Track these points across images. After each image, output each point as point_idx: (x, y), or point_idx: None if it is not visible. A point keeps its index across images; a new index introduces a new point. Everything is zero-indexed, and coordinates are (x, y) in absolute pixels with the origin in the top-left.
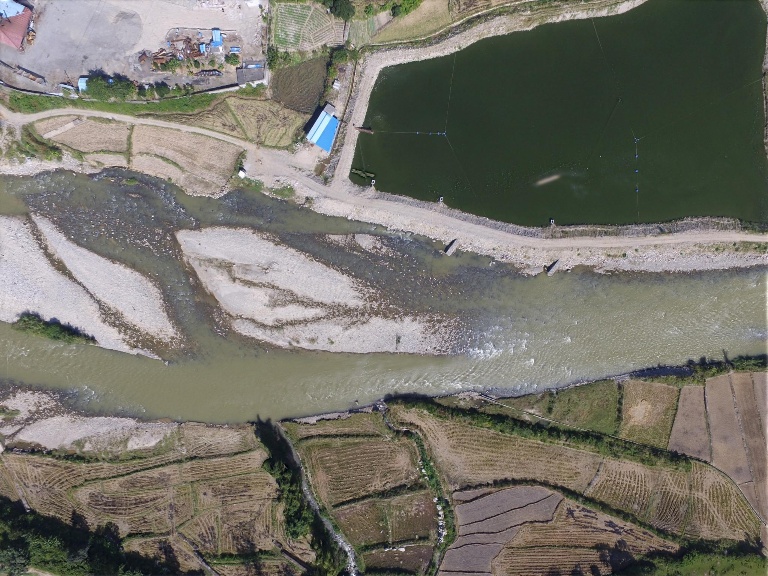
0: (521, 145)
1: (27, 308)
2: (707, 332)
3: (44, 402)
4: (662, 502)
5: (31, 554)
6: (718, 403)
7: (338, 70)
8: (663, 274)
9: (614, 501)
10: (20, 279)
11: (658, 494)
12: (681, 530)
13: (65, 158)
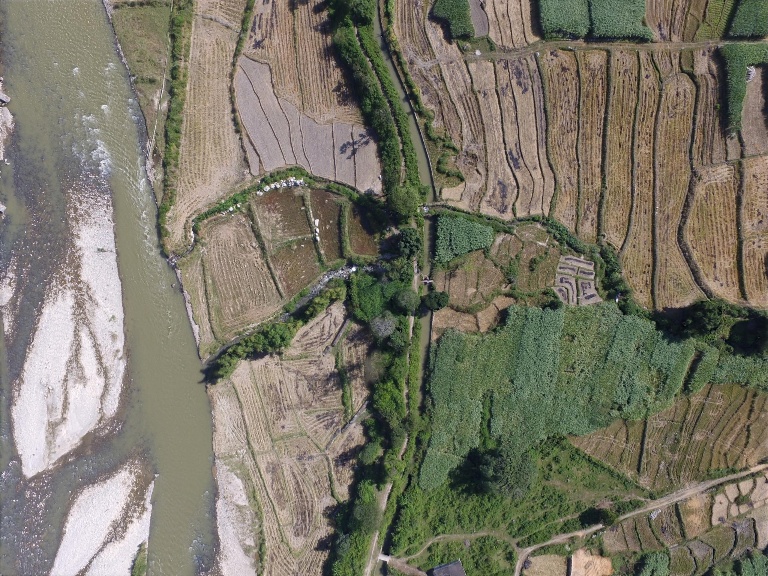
0: None
1: None
2: None
3: None
4: None
5: None
6: None
7: None
8: None
9: None
10: None
11: None
12: None
13: None
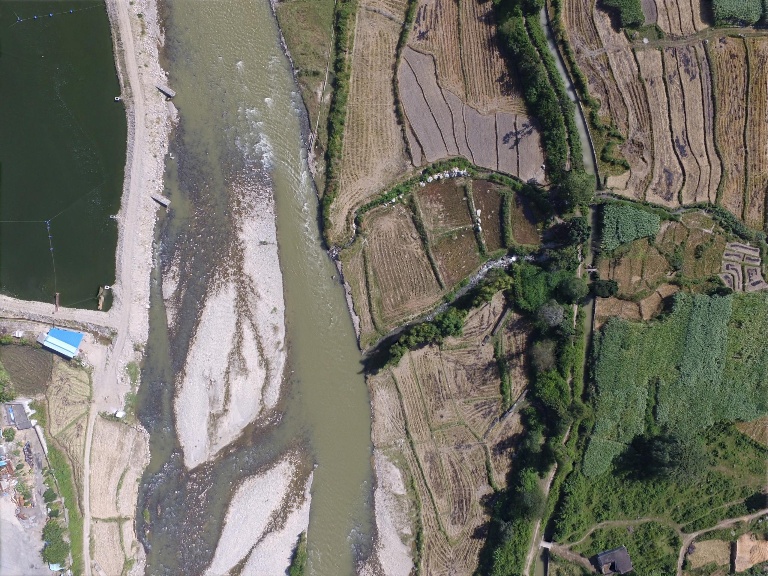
0: (45, 142)
1: None
2: None
3: (367, 574)
4: None
5: (509, 574)
6: None
7: (5, 334)
8: None
9: None
10: None
11: None
12: None
13: (133, 575)
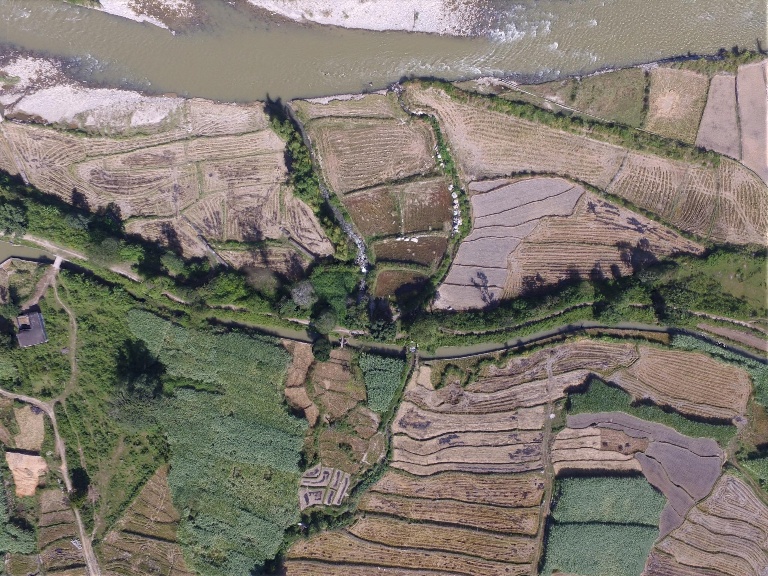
0: None
1: None
2: (741, 19)
3: (45, 70)
4: (688, 201)
5: (29, 218)
6: (750, 95)
7: None
8: None
9: (637, 199)
10: None
11: (684, 193)
12: (707, 233)
13: None
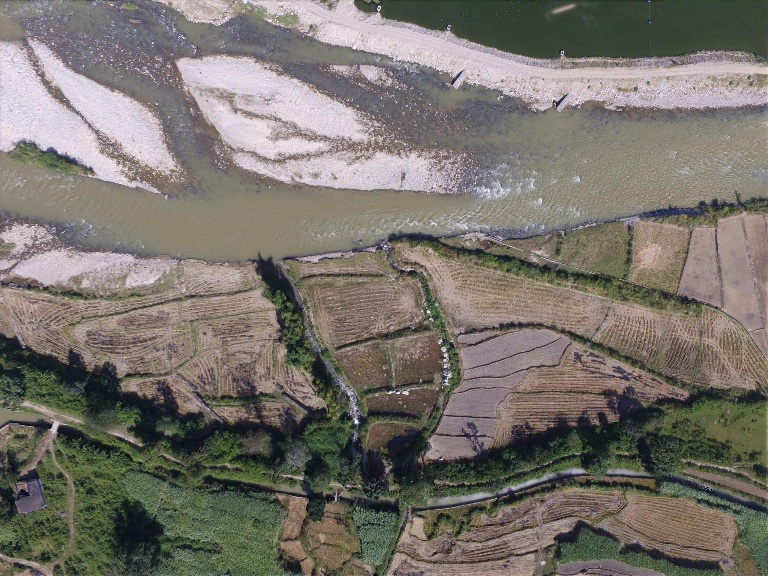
0: None
1: (23, 137)
2: (719, 173)
3: (41, 235)
4: (671, 349)
5: (27, 386)
6: (730, 246)
7: None
8: (675, 111)
9: (622, 347)
10: (16, 106)
11: (667, 341)
12: (691, 378)
13: None
